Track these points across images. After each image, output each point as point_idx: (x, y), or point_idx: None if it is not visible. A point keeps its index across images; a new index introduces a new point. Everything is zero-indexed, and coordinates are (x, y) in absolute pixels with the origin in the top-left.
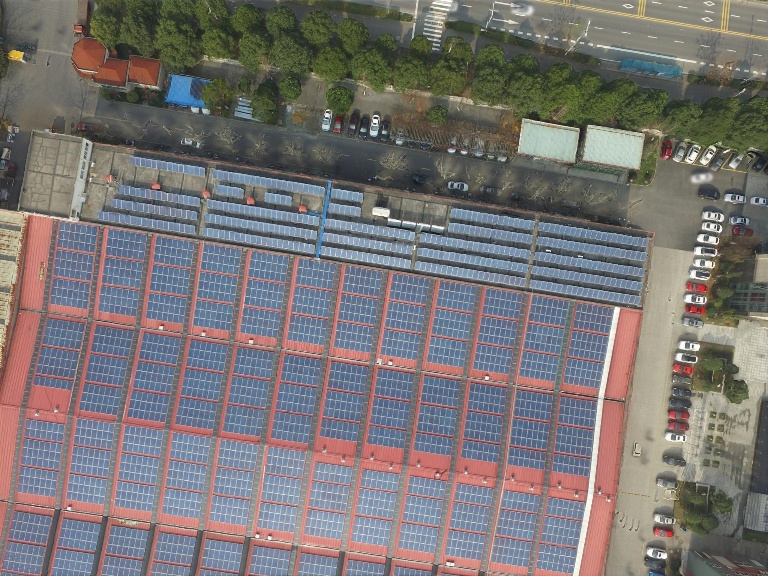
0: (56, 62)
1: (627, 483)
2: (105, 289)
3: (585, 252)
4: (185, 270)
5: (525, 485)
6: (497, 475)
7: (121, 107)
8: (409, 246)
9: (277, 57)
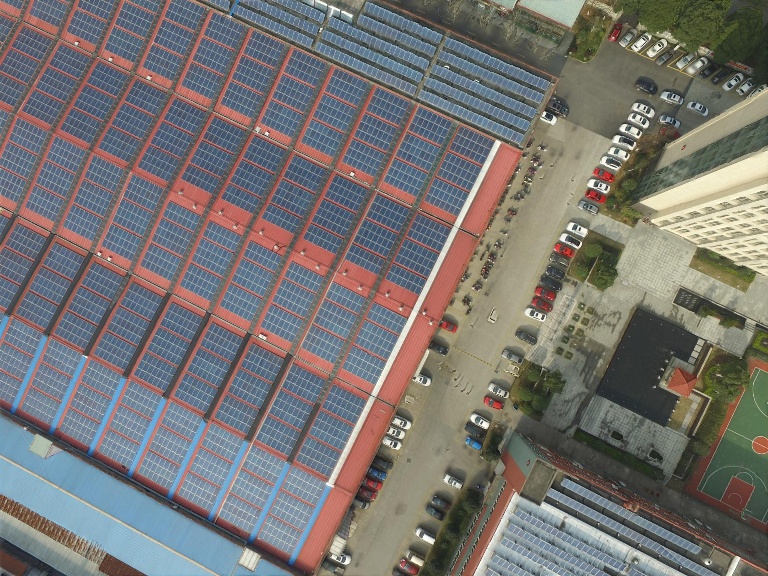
0: None
1: (473, 345)
2: None
3: (483, 79)
4: None
5: (355, 283)
6: (331, 266)
7: None
8: (315, 26)
9: None
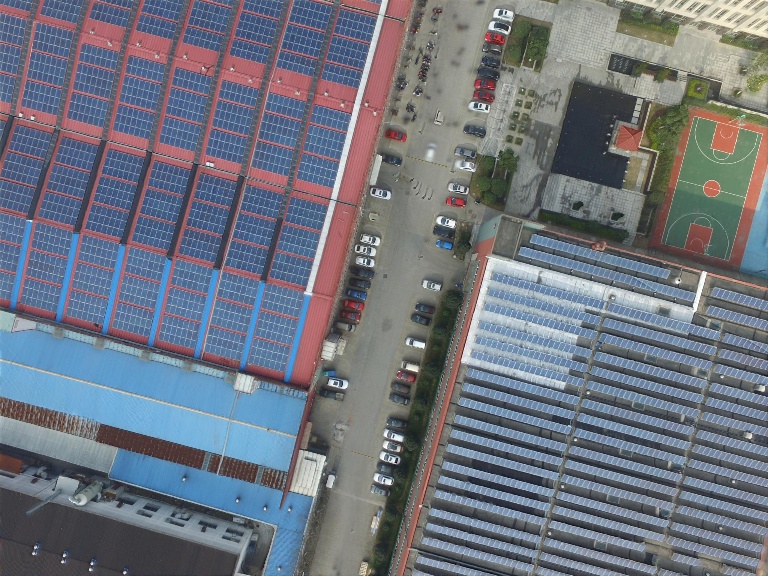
0: None
1: (425, 150)
2: None
3: None
4: None
5: (291, 89)
6: (264, 76)
7: None
8: None
9: None
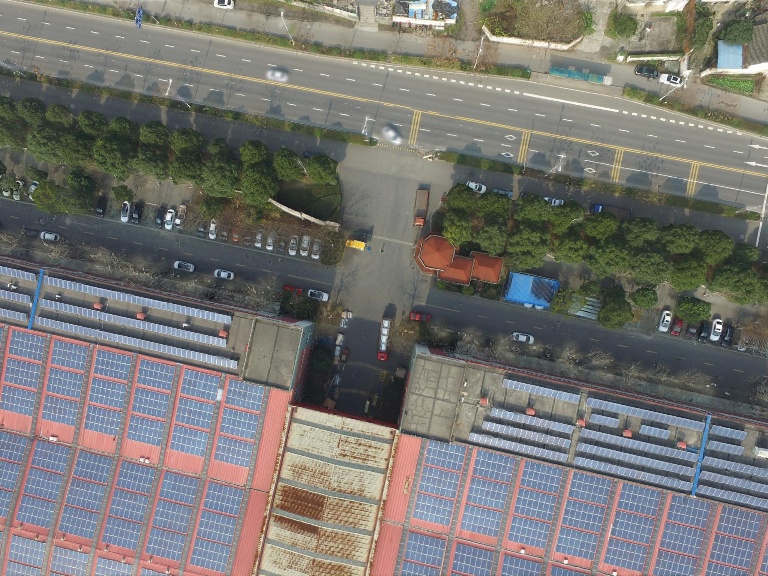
0: (390, 249)
1: None
2: (469, 508)
3: None
4: (552, 496)
5: None
6: None
7: (452, 297)
8: None
9: (638, 270)
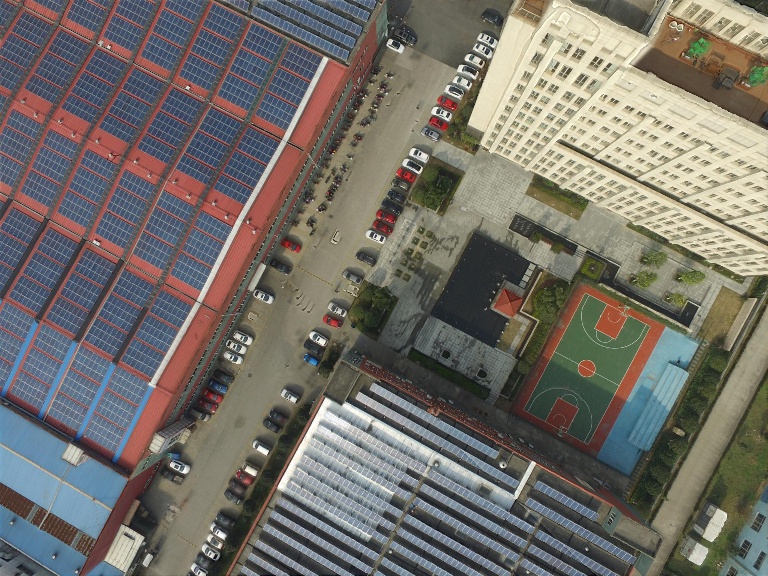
0: None
1: (316, 265)
2: None
3: None
4: None
5: (184, 192)
6: (163, 175)
7: None
8: None
9: None
